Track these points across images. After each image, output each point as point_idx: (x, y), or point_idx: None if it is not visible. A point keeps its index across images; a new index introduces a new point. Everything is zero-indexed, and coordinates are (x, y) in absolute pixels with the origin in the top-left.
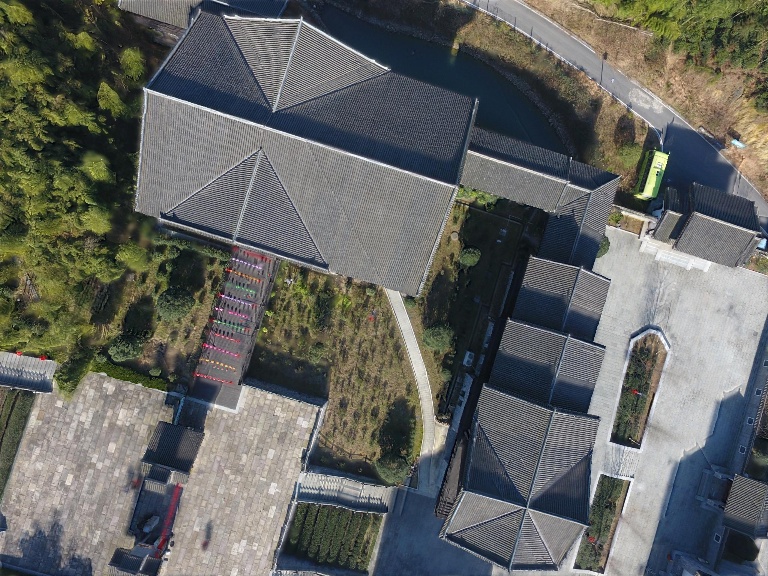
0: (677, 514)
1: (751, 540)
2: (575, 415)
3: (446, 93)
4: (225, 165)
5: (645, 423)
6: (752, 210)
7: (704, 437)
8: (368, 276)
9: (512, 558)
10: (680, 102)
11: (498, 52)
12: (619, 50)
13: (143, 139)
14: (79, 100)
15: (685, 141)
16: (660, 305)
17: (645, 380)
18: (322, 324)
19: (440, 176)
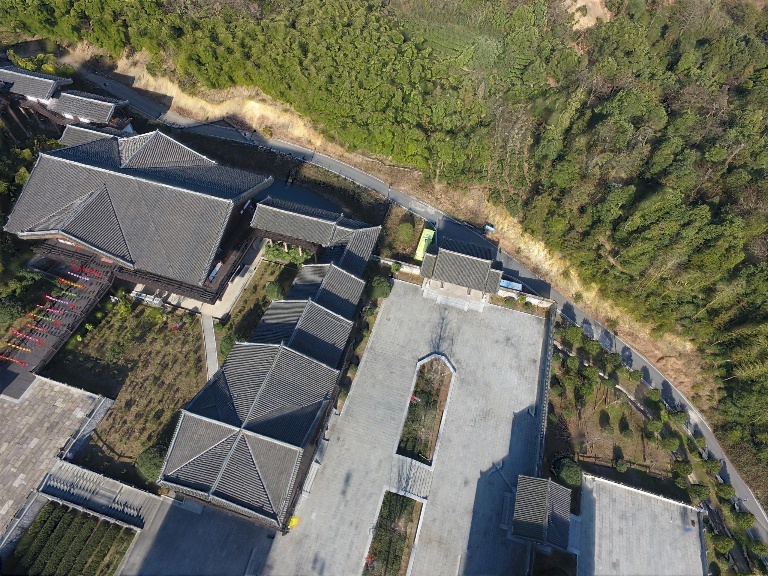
0: (481, 547)
1: (562, 570)
2: (306, 356)
3: (252, 174)
4: (78, 196)
5: (436, 440)
6: (490, 252)
7: (500, 457)
8: (164, 270)
9: (215, 481)
10: (446, 208)
11: (315, 180)
12: (400, 181)
13: (28, 182)
14: (3, 178)
15: (453, 229)
16: (444, 336)
17: (433, 398)
18: (135, 341)
19: (223, 197)
